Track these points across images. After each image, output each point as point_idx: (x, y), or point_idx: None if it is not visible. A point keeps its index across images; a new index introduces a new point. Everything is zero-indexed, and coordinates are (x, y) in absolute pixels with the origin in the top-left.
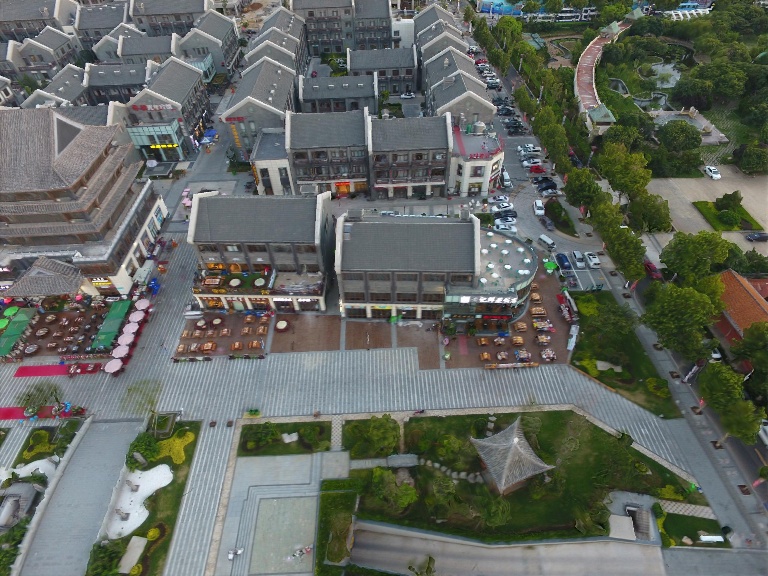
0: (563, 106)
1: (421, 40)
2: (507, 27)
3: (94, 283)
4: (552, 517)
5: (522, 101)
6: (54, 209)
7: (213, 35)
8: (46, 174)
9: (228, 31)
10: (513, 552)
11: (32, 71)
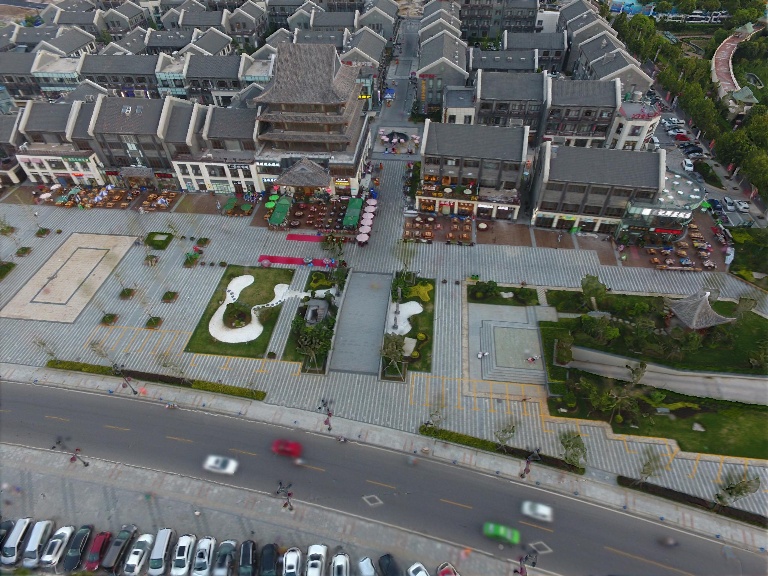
0: (706, 88)
1: (571, 27)
2: (641, 24)
3: (336, 183)
4: (726, 361)
5: (668, 81)
6: (325, 120)
7: (387, 14)
8: (327, 92)
9: (395, 12)
10: (695, 379)
11: (237, 35)
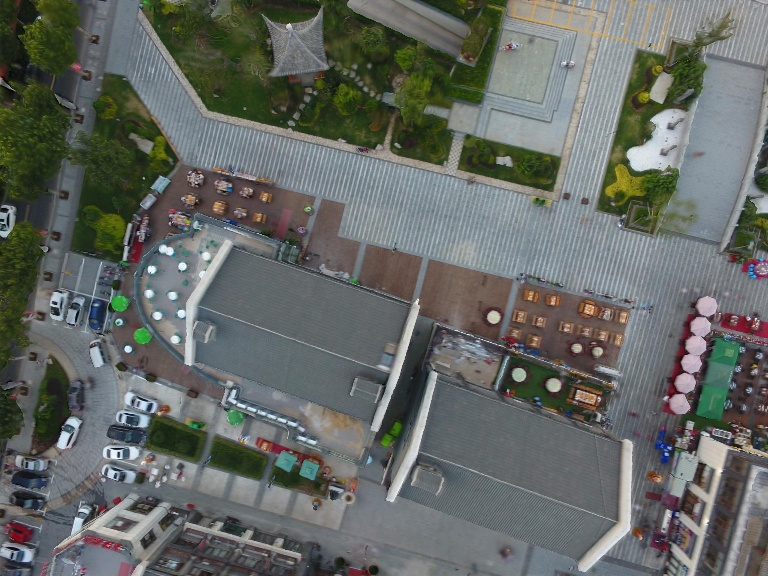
0: None
1: None
2: None
3: None
4: (283, 15)
5: None
6: None
7: None
8: None
9: None
10: None
11: None
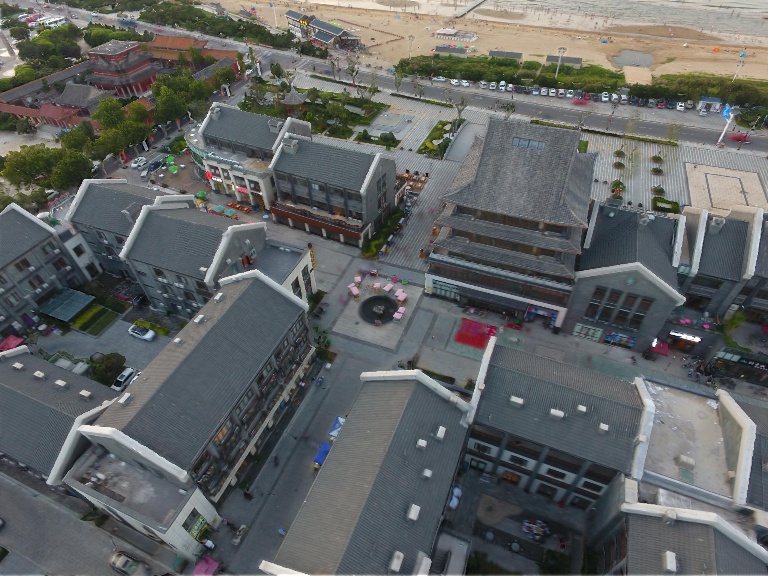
0: None
1: None
2: None
3: None
4: None
5: None
6: None
7: None
8: None
9: None
10: None
11: None
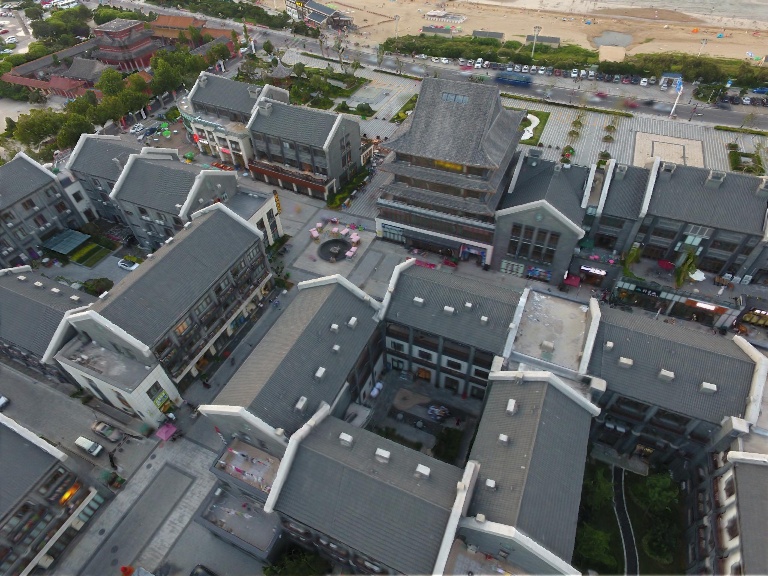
0: None
1: None
2: None
3: None
4: None
5: None
6: None
7: None
8: None
9: None
10: None
11: None
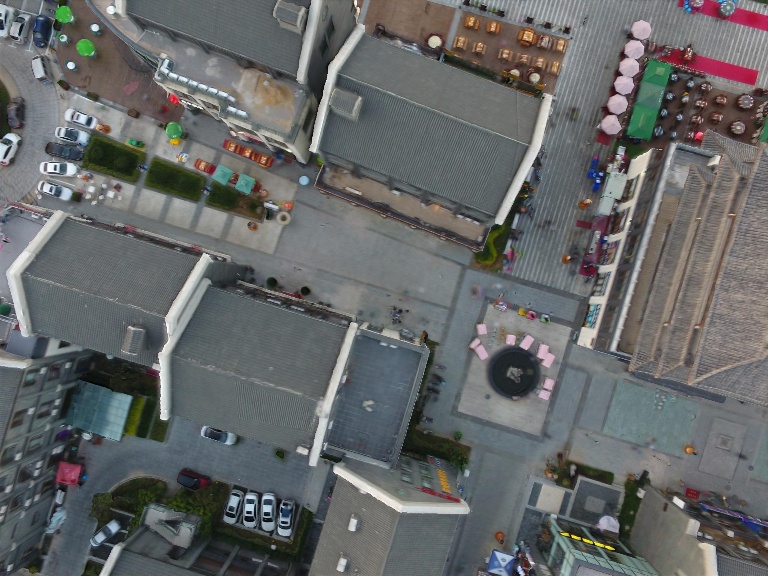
0: None
1: None
2: None
3: None
4: None
5: None
6: None
7: None
8: None
9: None
10: None
11: None
